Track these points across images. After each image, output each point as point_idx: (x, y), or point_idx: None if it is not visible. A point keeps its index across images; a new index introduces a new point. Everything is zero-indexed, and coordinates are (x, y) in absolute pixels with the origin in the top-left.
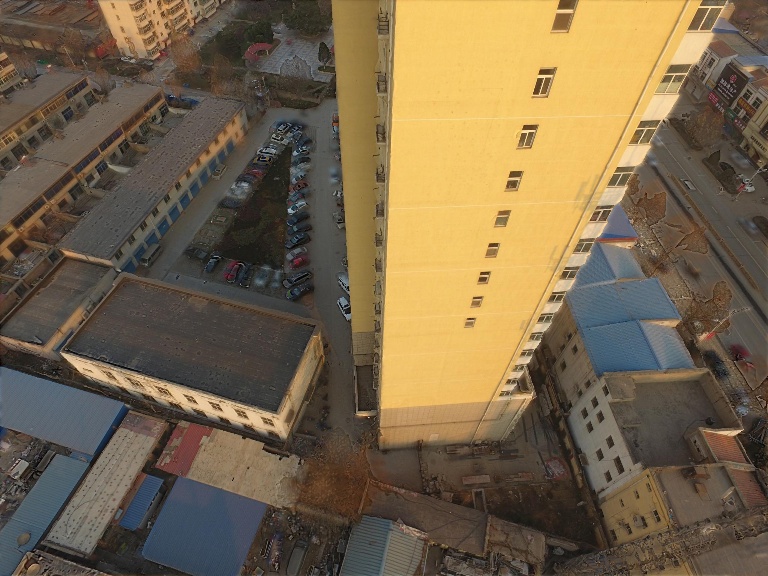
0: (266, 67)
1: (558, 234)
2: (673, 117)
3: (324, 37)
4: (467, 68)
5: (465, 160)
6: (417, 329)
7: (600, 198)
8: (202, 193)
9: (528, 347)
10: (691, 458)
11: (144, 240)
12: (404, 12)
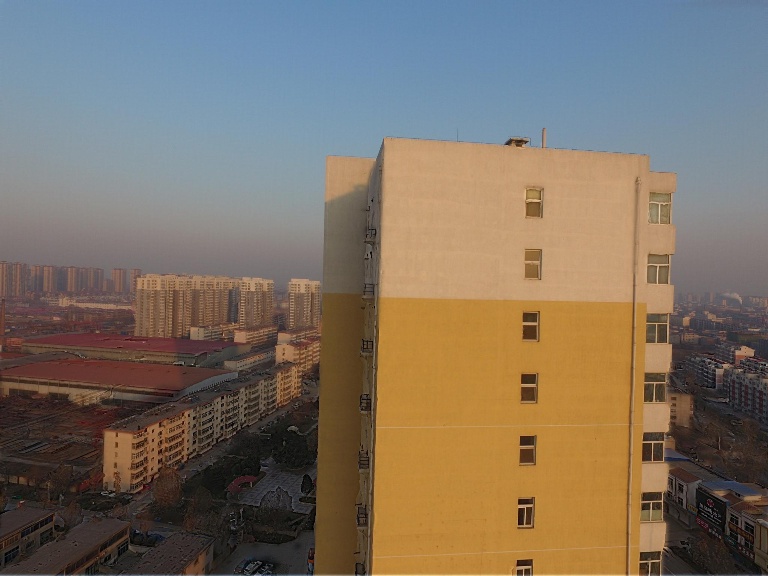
0: (247, 499)
1: None
2: (672, 545)
3: (309, 469)
4: (447, 499)
5: None
6: None
7: None
8: None
9: None
10: None
11: None
12: (383, 449)
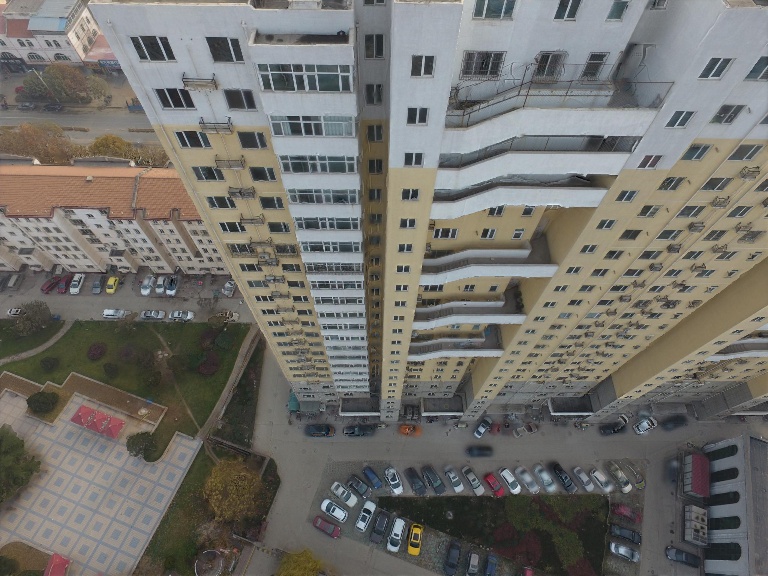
0: (114, 566)
1: None
2: None
3: None
4: None
5: None
6: None
7: None
8: None
9: None
10: None
11: None
12: None
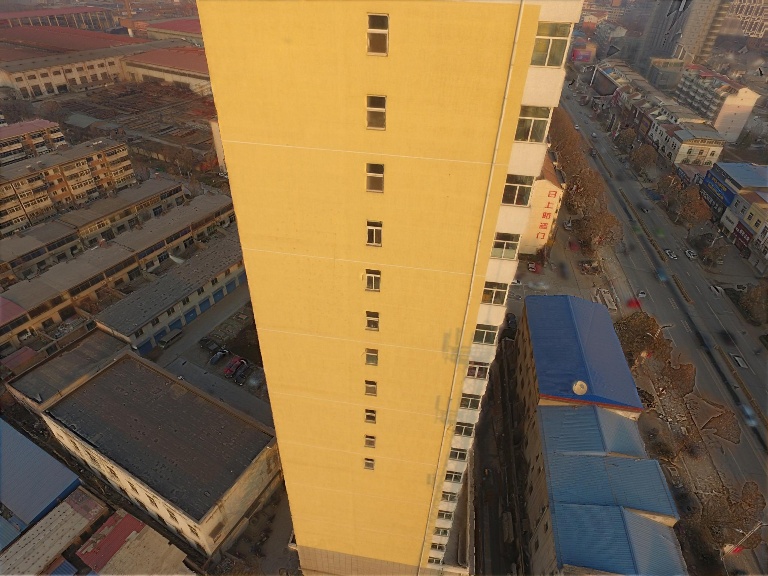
0: None
1: (436, 383)
2: (730, 287)
3: None
4: (298, 212)
5: (318, 293)
6: (314, 459)
7: (470, 353)
8: (237, 291)
9: (444, 508)
10: None
11: (168, 324)
12: (232, 162)
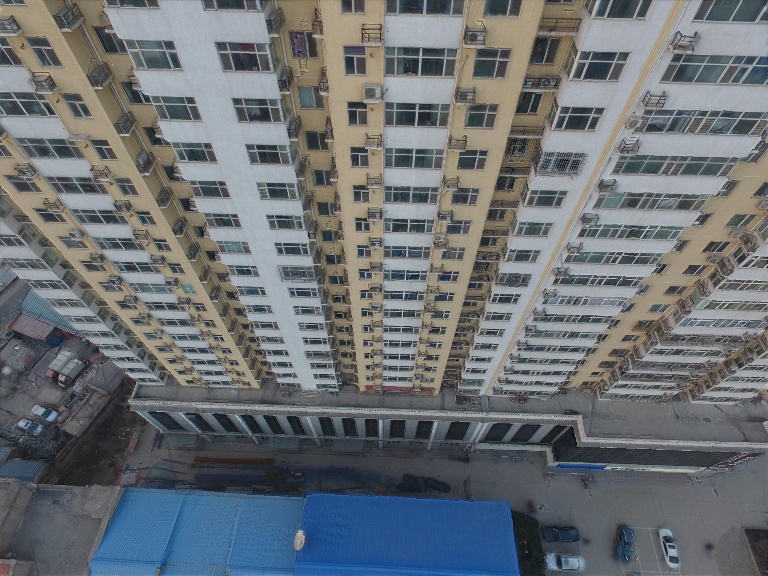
0: None
1: None
2: None
3: None
4: None
5: None
6: None
7: None
8: None
9: None
10: (14, 556)
11: None
12: None
